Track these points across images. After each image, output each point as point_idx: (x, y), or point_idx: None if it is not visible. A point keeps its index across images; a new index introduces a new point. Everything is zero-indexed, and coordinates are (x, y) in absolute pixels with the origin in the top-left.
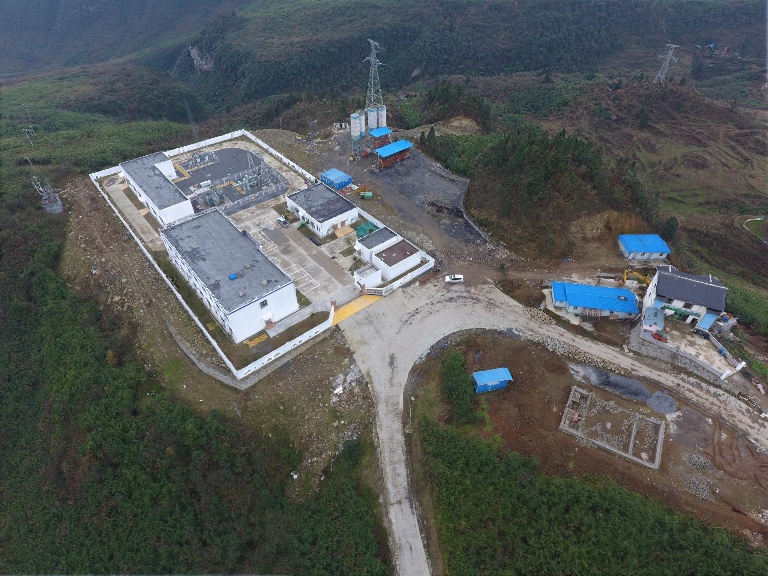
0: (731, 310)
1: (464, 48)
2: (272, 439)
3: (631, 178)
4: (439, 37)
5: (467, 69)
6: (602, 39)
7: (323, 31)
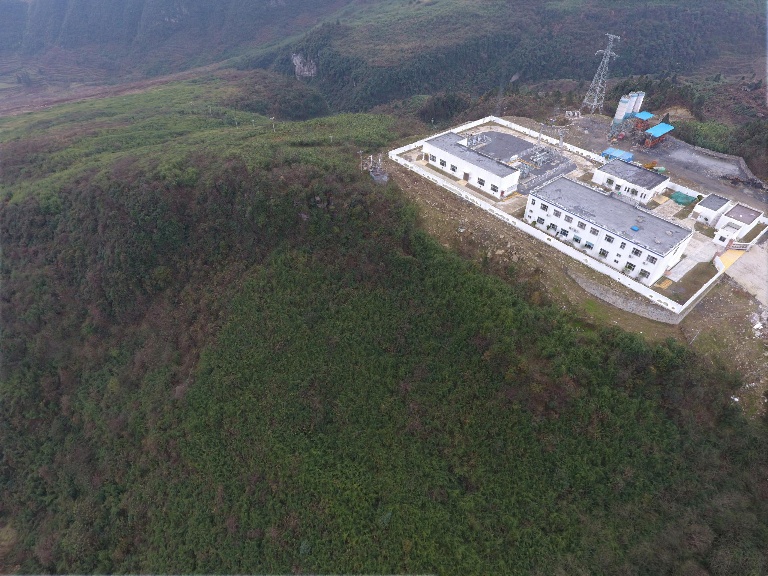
0: None
1: (563, 55)
2: (714, 366)
3: None
4: (539, 44)
5: (565, 75)
6: (697, 46)
7: (430, 38)
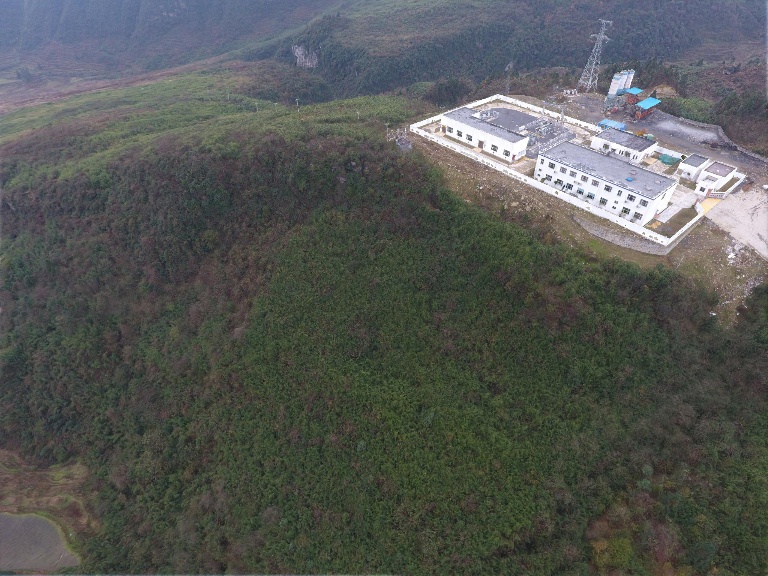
0: None
1: (555, 44)
2: None
3: None
4: (532, 34)
5: (557, 63)
6: (682, 34)
7: (428, 29)
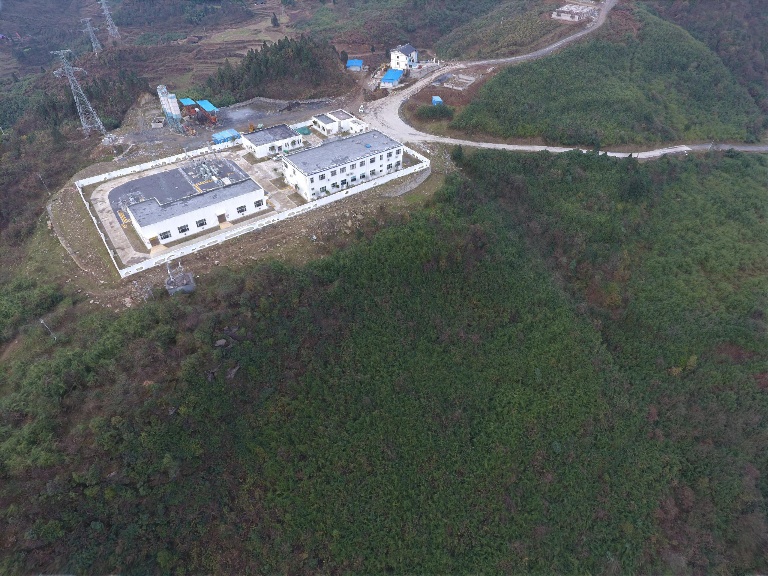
0: None
1: None
2: None
3: None
4: None
5: None
6: None
7: None
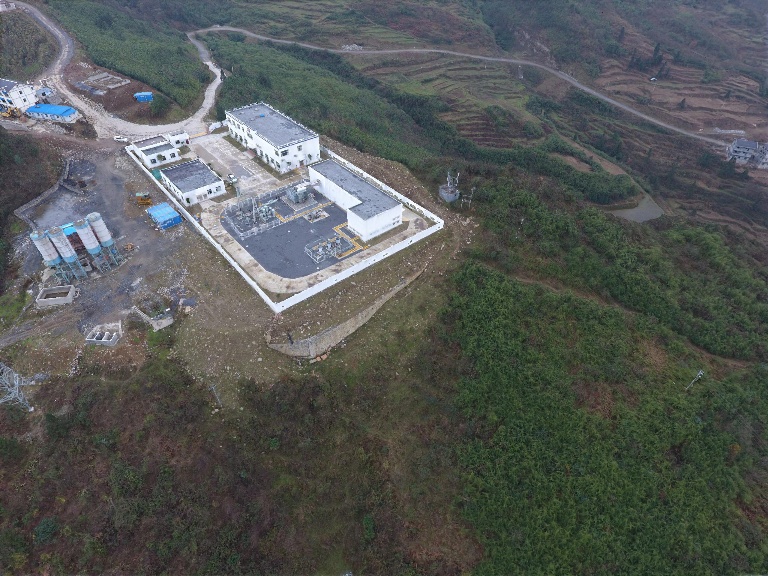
0: None
1: None
2: None
3: None
4: None
5: None
6: None
7: None
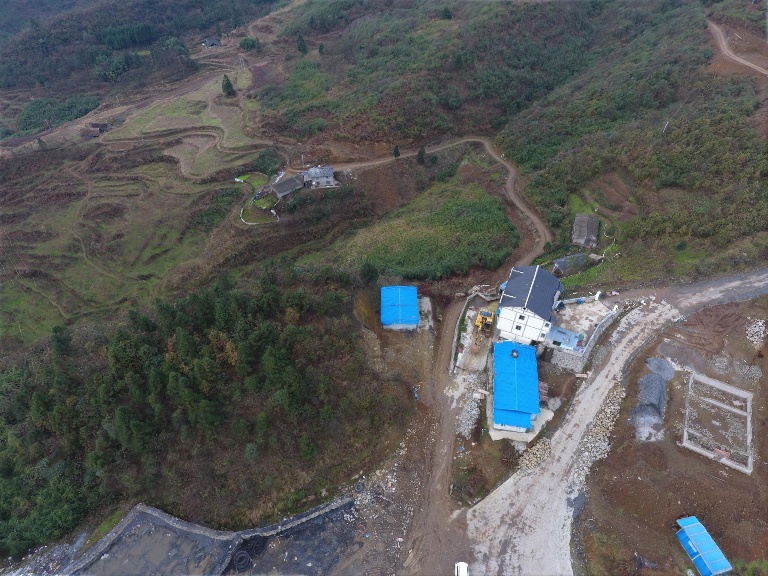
0: (439, 277)
1: None
2: None
3: (313, 272)
4: None
5: None
6: None
7: None
